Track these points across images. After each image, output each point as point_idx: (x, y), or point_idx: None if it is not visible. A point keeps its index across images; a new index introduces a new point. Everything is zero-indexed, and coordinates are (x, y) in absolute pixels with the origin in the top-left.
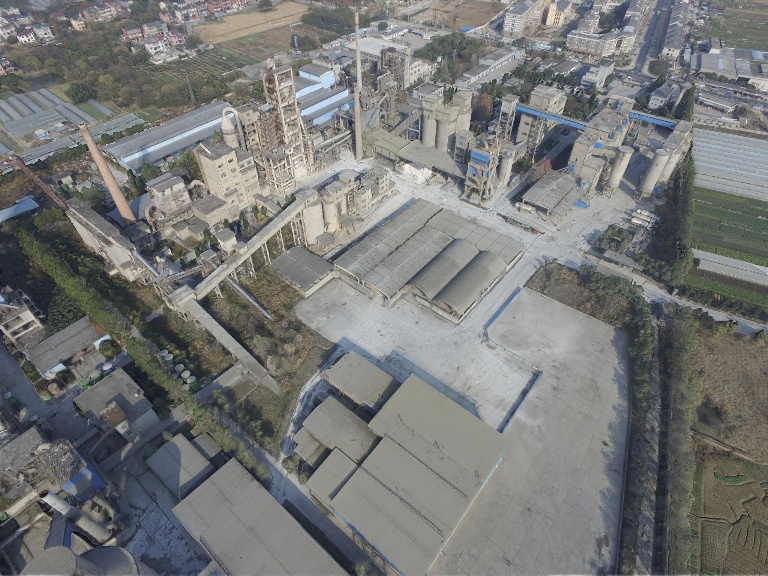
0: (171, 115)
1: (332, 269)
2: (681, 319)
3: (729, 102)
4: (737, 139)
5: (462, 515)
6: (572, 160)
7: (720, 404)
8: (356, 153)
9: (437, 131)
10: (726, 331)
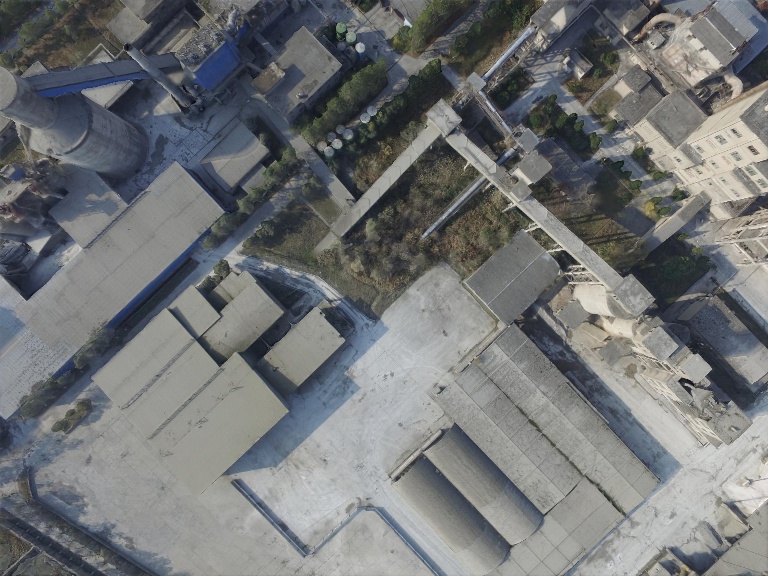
0: None
1: None
2: None
3: None
4: None
5: None
6: None
7: None
8: None
9: None
10: None
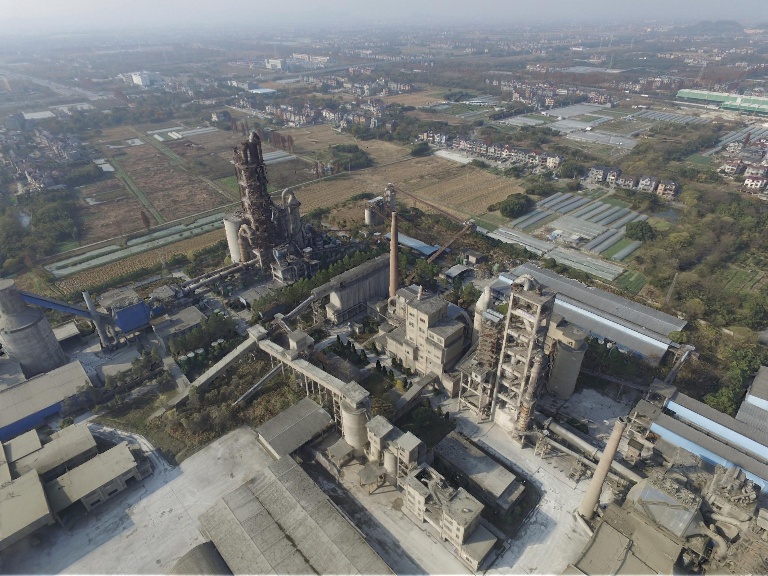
0: (631, 293)
1: None
2: None
3: None
4: None
5: None
6: None
7: None
8: None
9: None
10: None
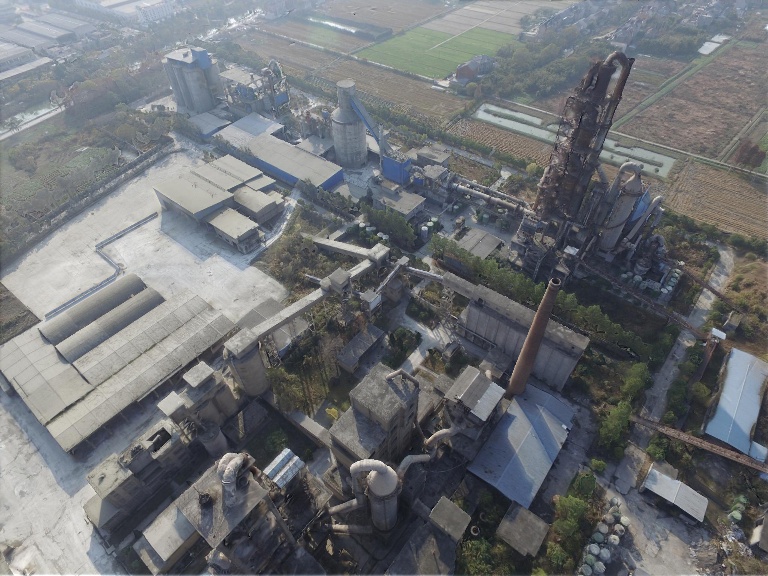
0: None
1: None
2: None
3: None
4: None
5: None
6: None
7: None
8: None
9: None
10: None
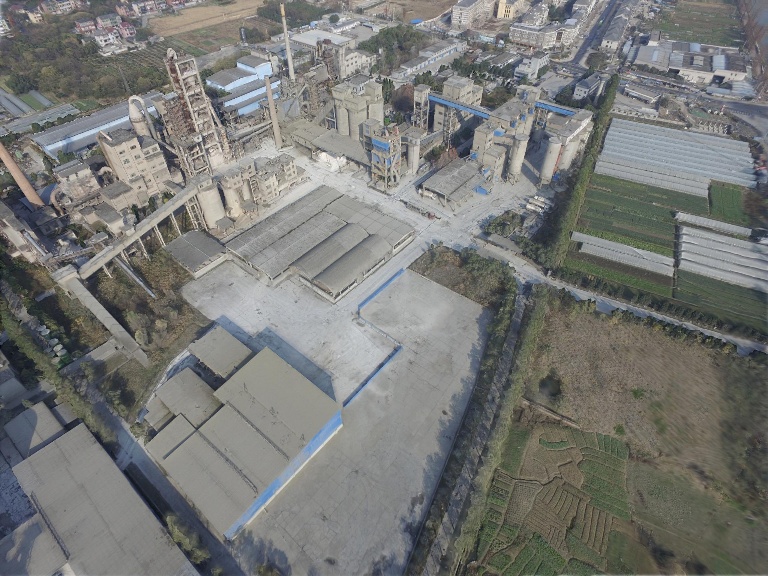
0: (106, 105)
1: (224, 251)
2: (538, 297)
3: (653, 93)
4: (653, 129)
5: (286, 475)
6: (474, 148)
7: (563, 377)
8: (275, 142)
9: (349, 120)
10: (586, 310)
